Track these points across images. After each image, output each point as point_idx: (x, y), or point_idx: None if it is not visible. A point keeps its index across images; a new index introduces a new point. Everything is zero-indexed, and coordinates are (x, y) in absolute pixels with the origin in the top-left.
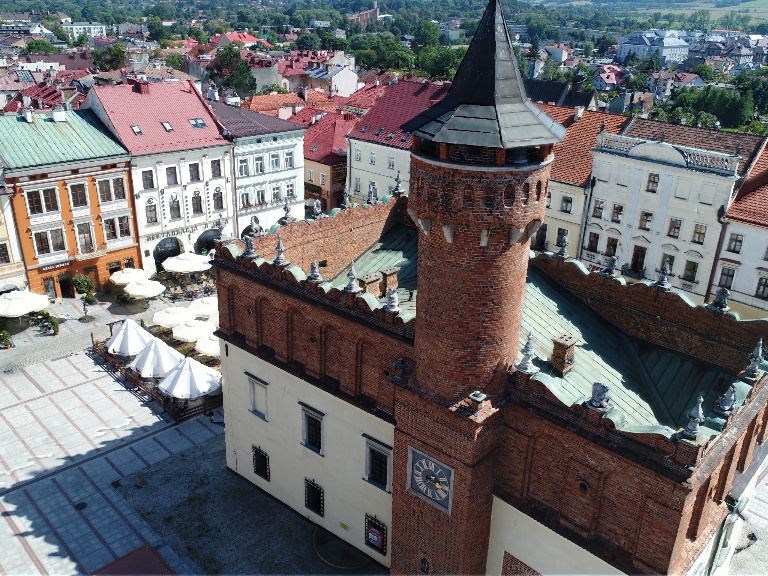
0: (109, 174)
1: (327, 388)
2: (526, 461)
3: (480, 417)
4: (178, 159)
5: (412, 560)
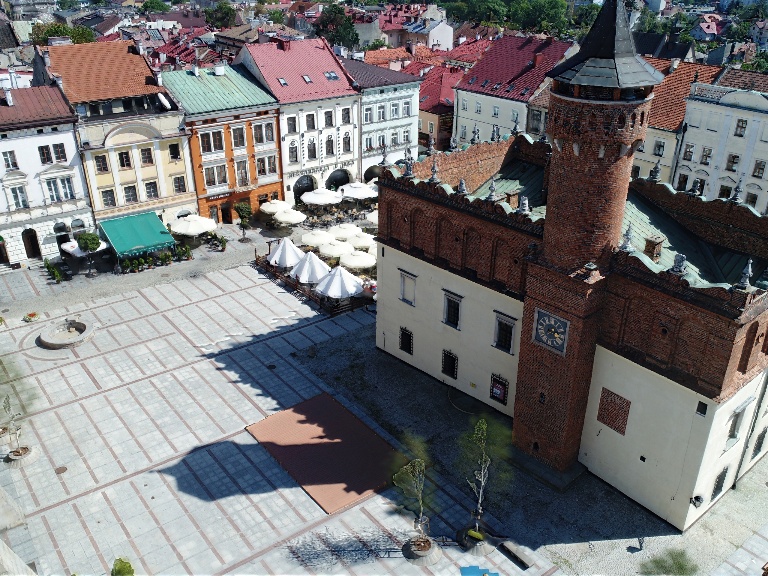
0: (262, 120)
1: (467, 276)
2: (623, 317)
3: (592, 280)
4: (316, 107)
5: (532, 395)
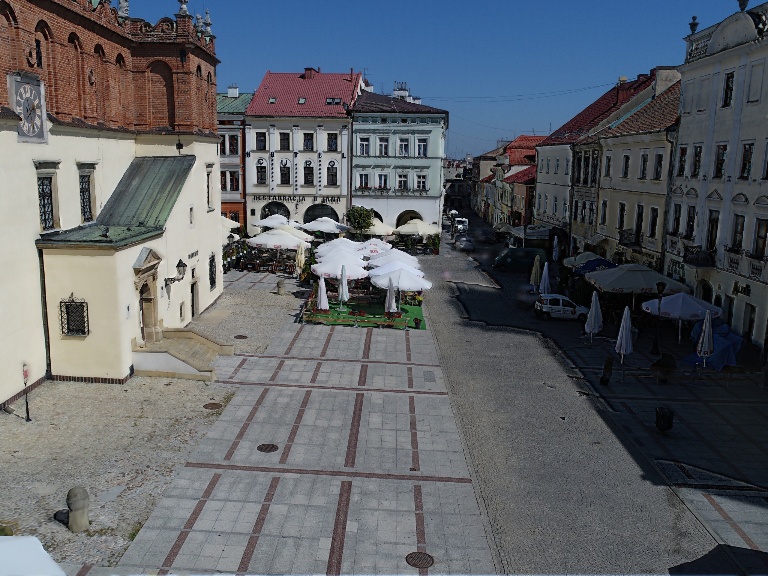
0: (226, 129)
1: None
2: None
3: None
4: (292, 126)
5: None
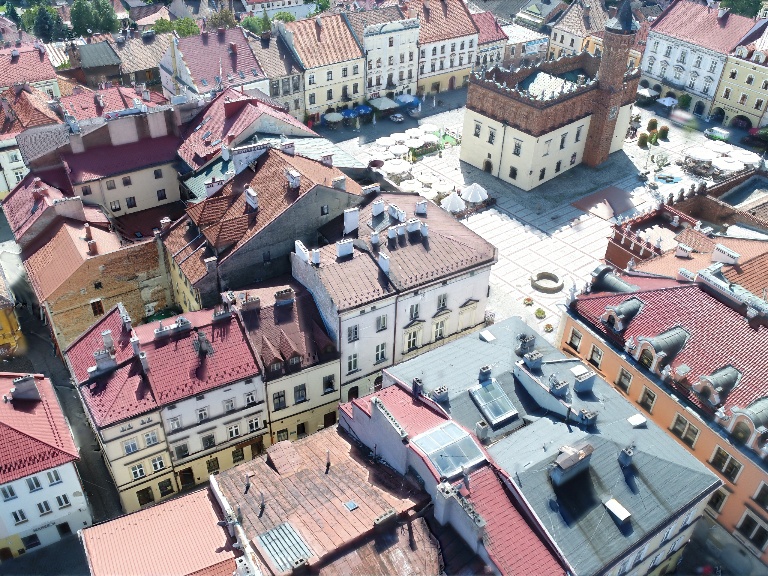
0: None
1: (571, 122)
2: None
3: None
4: None
5: None
